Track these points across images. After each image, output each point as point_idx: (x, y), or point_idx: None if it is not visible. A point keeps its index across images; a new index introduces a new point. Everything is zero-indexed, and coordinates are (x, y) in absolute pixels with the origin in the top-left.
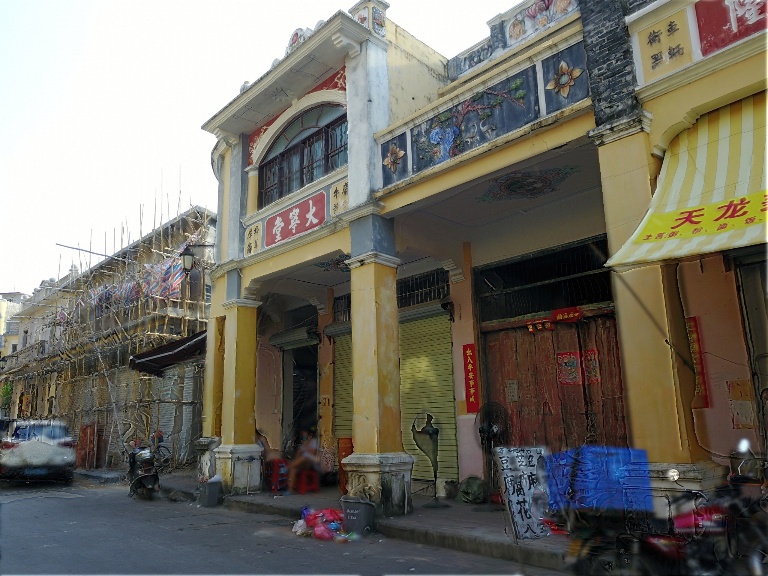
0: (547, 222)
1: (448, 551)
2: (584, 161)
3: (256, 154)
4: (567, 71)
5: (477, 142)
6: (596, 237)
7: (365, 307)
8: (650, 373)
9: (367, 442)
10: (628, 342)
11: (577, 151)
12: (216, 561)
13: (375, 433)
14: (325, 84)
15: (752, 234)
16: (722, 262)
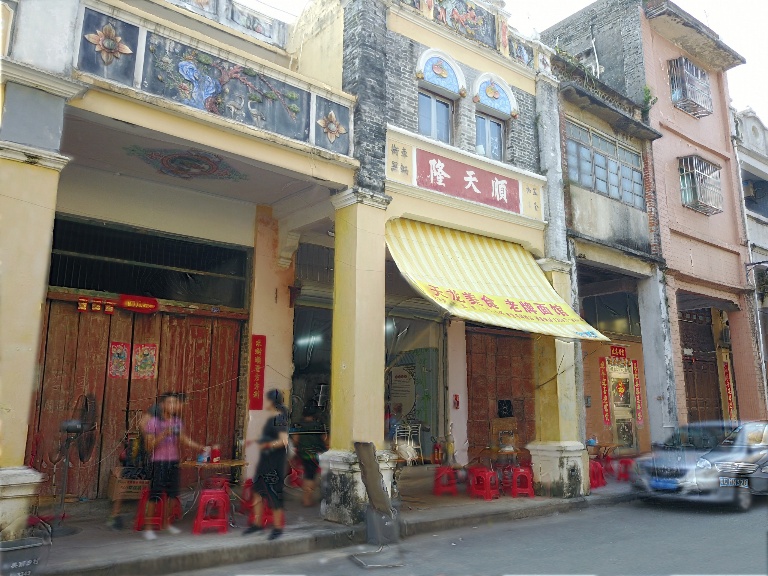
0: (142, 199)
1: (197, 572)
2: (260, 180)
3: None
4: (335, 122)
5: (242, 118)
6: (188, 237)
7: (28, 231)
8: (373, 385)
9: (1, 449)
10: (362, 360)
11: (291, 179)
12: None
13: (24, 434)
14: None
15: (491, 319)
16: (289, 299)
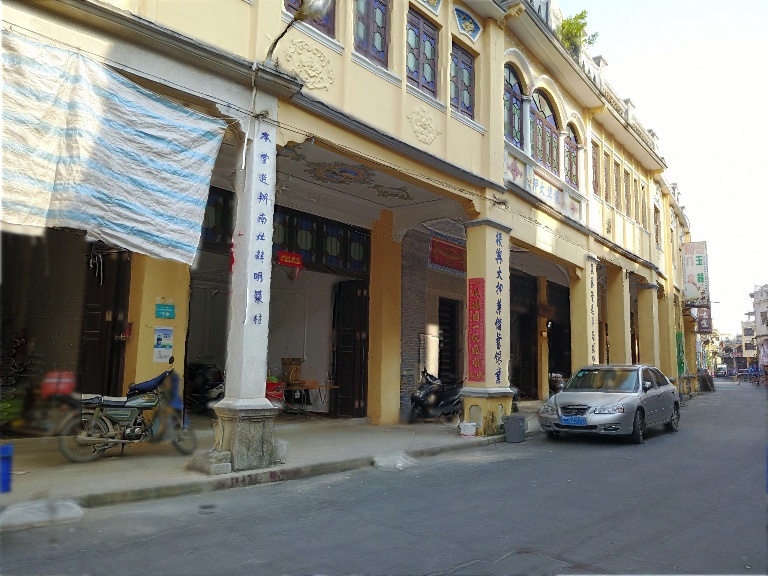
0: None
1: None
2: None
3: None
4: None
5: None
6: None
7: None
8: None
9: None
10: None
11: None
12: None
13: None
14: None
15: None
16: None
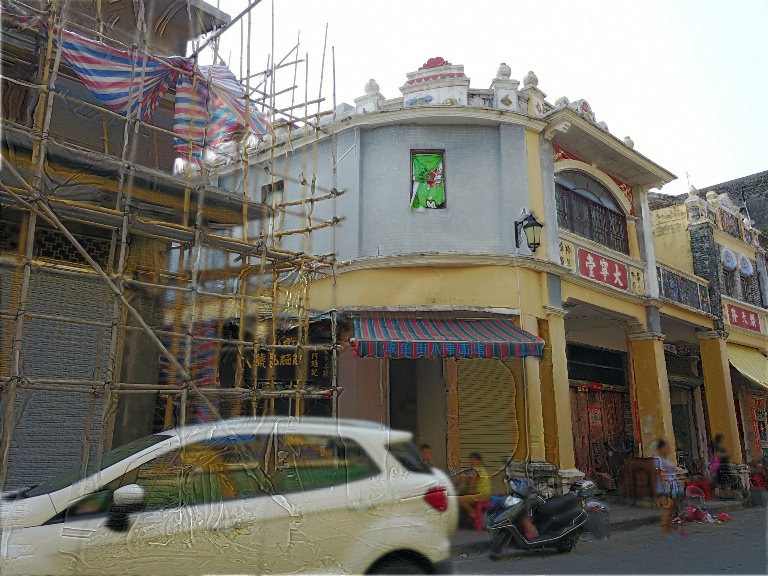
0: (593, 330)
1: (726, 513)
2: None
3: (555, 168)
4: None
5: None
6: None
7: None
8: None
9: None
10: None
11: None
12: None
13: None
14: (615, 181)
15: None
16: None
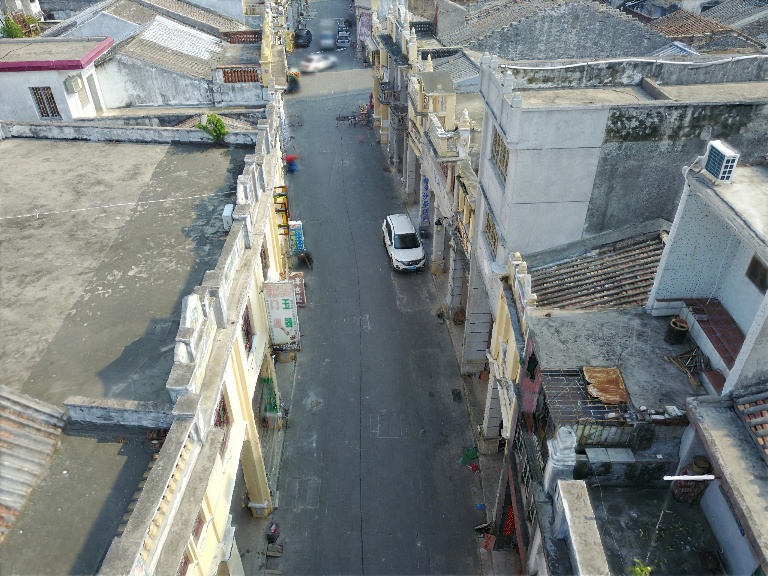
0: None
1: None
2: None
3: None
4: None
5: None
6: None
7: None
8: None
9: None
10: None
11: None
12: (341, 10)
13: None
14: None
15: None
16: None
